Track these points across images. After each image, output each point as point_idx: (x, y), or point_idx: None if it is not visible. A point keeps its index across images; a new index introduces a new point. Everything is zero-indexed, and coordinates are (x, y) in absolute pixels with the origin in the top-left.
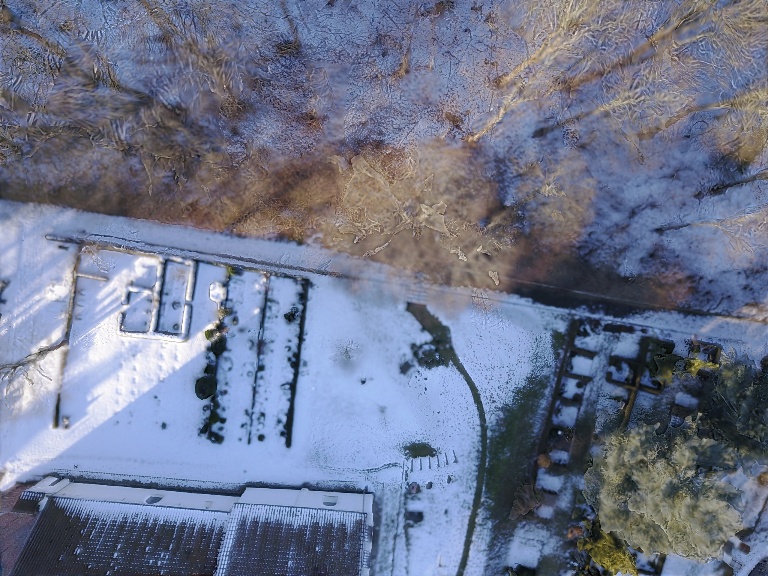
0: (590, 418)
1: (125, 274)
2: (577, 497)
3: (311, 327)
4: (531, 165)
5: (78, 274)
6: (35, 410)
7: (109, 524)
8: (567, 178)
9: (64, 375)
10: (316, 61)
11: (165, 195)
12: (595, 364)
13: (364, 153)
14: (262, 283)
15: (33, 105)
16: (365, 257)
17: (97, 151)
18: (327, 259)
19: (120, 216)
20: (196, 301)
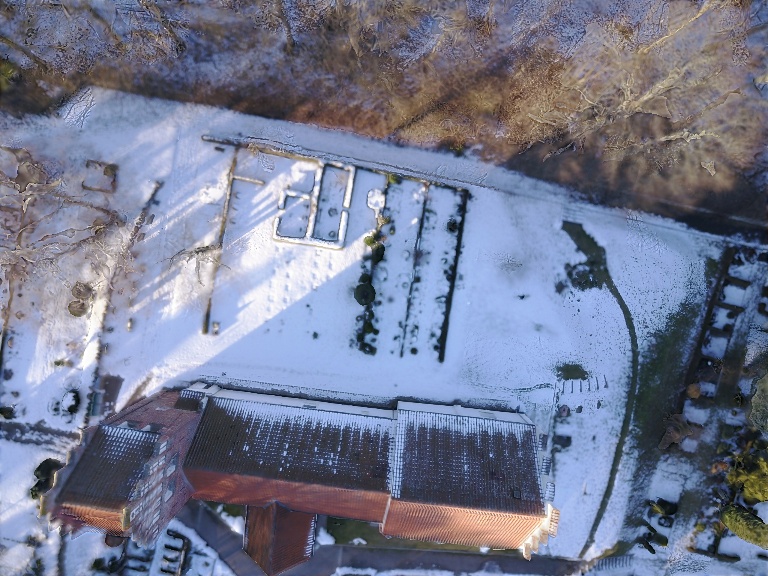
0: (740, 350)
1: (281, 178)
2: (724, 431)
3: (468, 240)
4: None
5: (235, 176)
6: (185, 314)
7: (273, 425)
8: (736, 96)
9: (216, 280)
10: None
11: (325, 98)
12: (747, 295)
13: (531, 61)
14: (420, 192)
15: None
16: (521, 172)
17: (259, 50)
18: (483, 173)
19: (277, 119)
20: (353, 208)
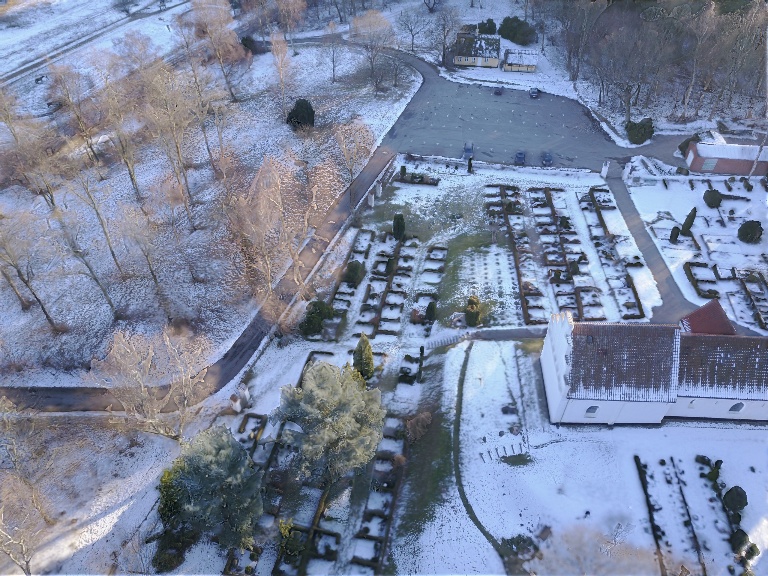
0: (356, 500)
1: None
2: None
3: (653, 568)
4: None
5: None
6: None
7: None
8: None
9: None
10: None
11: None
12: (351, 552)
13: None
14: None
15: None
16: None
17: None
18: None
19: None
20: None
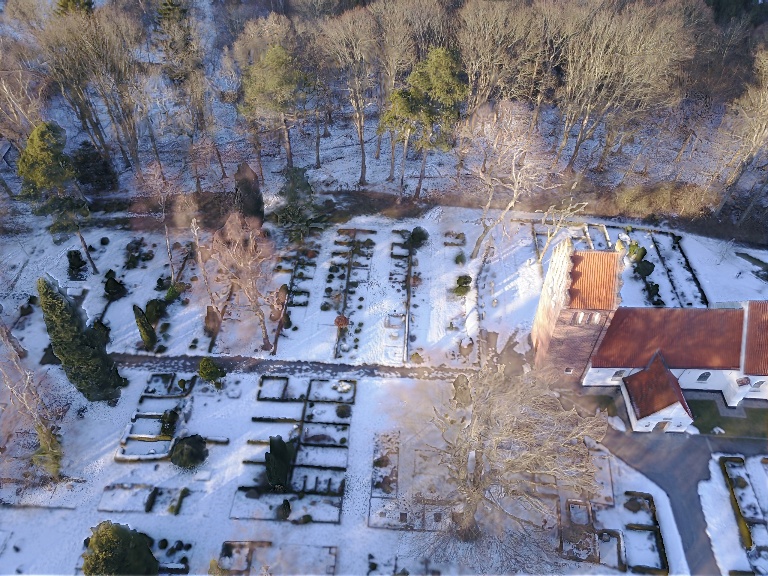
0: None
1: (564, 233)
2: None
3: (688, 254)
4: (766, 193)
5: (537, 232)
6: (529, 296)
7: None
8: None
9: (543, 278)
10: (631, 157)
11: (573, 203)
12: None
13: None
14: (647, 235)
15: (620, 56)
16: (695, 235)
17: None
18: None
19: None
20: None
